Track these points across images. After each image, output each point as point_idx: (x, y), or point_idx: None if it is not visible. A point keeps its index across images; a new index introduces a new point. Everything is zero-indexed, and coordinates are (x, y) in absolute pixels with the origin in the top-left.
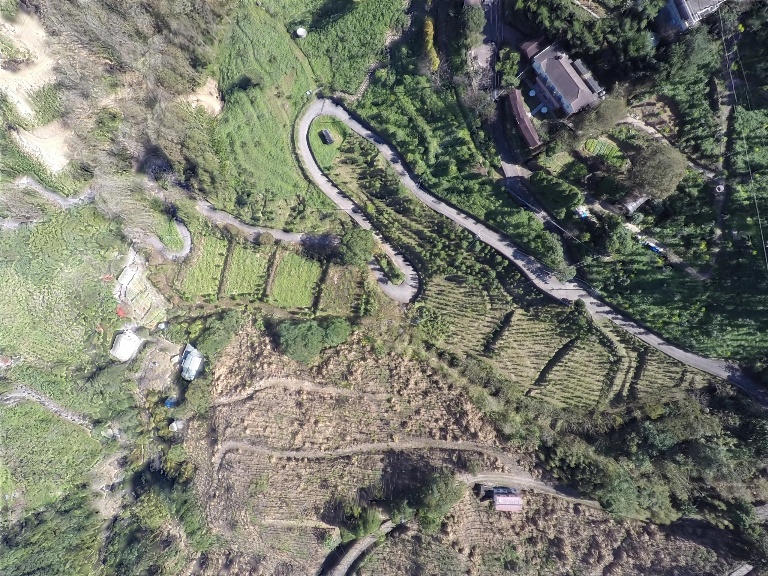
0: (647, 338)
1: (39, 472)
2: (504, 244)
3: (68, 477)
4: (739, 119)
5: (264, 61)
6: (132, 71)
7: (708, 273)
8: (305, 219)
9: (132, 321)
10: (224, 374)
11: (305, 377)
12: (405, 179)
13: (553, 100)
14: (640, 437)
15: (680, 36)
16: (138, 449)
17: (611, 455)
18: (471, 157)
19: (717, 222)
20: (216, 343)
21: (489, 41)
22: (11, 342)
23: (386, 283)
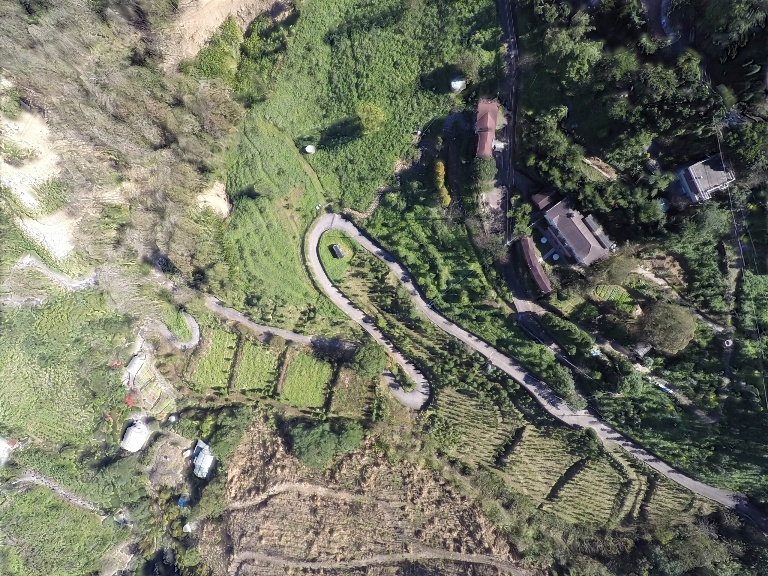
0: (657, 465)
1: (51, 560)
2: (515, 368)
3: (80, 566)
4: (747, 282)
5: (273, 174)
6: (137, 167)
7: (717, 417)
8: (315, 324)
9: (142, 411)
10: (237, 475)
11: (318, 481)
12: (416, 299)
13: (564, 249)
14: (651, 563)
15: (690, 208)
16: None
17: (623, 575)
18: (483, 290)
19: (726, 372)
20: (228, 444)
21: (500, 185)
22: (18, 422)
23: (397, 389)
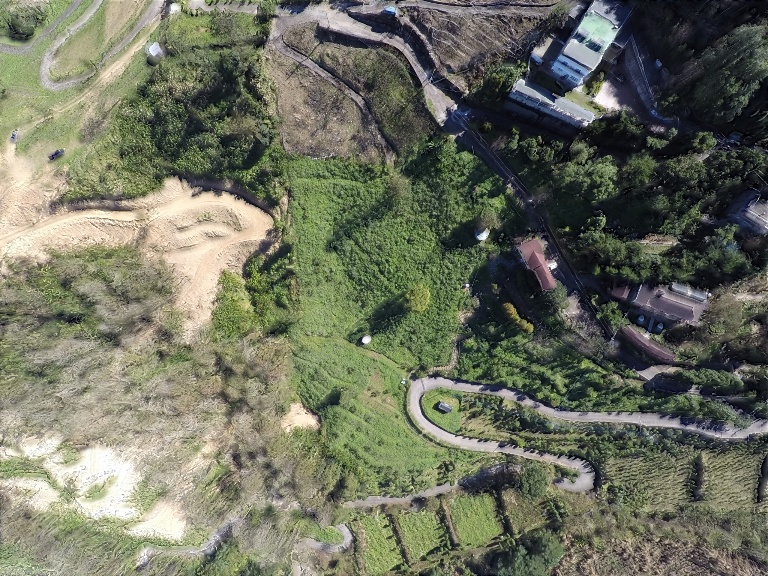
0: None
1: None
2: (668, 418)
3: None
4: None
5: (344, 376)
6: None
7: None
8: (456, 471)
9: None
10: None
11: None
12: (542, 410)
13: None
14: None
15: (766, 239)
16: None
17: None
18: (605, 378)
19: None
20: None
21: (571, 293)
22: None
23: (562, 481)
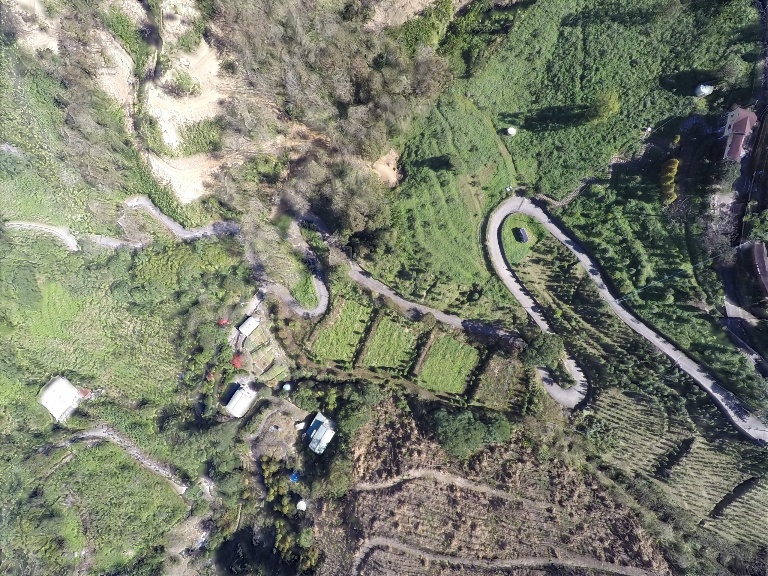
0: None
1: (115, 528)
2: (703, 375)
3: (150, 538)
4: None
5: (464, 150)
6: (300, 124)
7: None
8: (474, 307)
9: (250, 375)
10: (364, 454)
11: (456, 471)
12: (604, 293)
13: None
14: None
15: None
16: (231, 514)
17: None
18: (691, 290)
19: None
20: (360, 420)
21: (734, 189)
22: (90, 371)
23: (551, 384)
